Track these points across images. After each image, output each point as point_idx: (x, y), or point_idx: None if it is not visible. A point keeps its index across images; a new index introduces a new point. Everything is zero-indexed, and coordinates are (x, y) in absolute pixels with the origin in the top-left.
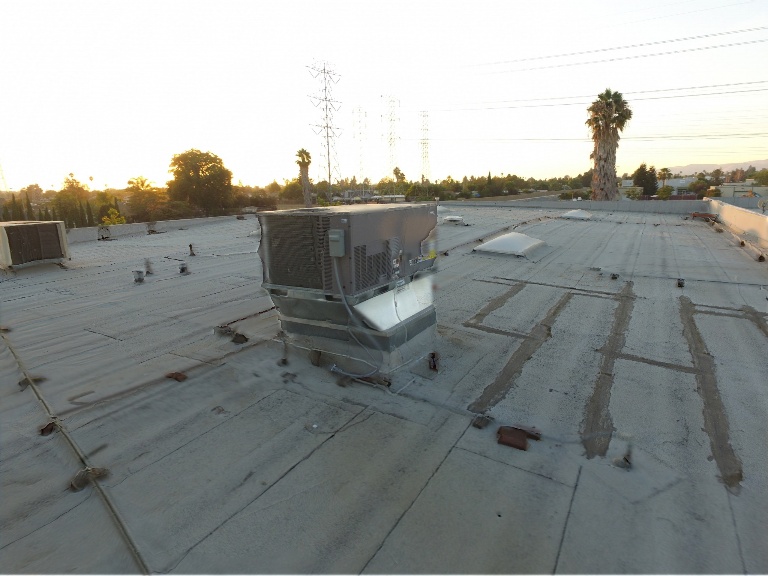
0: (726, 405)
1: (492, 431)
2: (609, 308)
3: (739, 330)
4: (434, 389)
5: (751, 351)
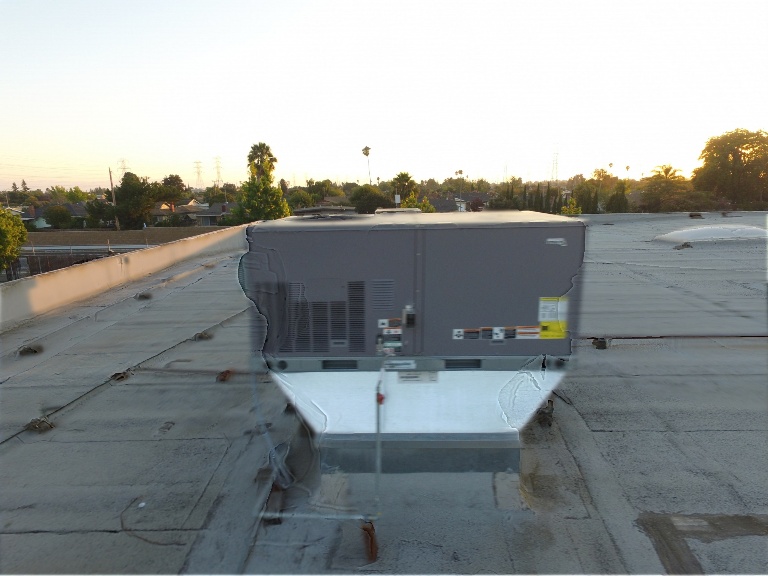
0: None
1: None
2: None
3: None
4: None
5: None
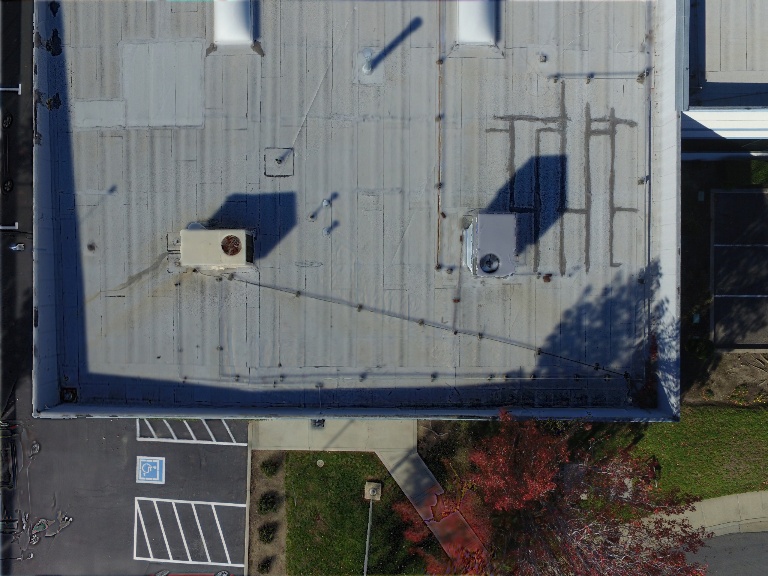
0: (591, 233)
1: (542, 279)
2: (557, 150)
3: (603, 155)
4: (522, 267)
5: (603, 182)
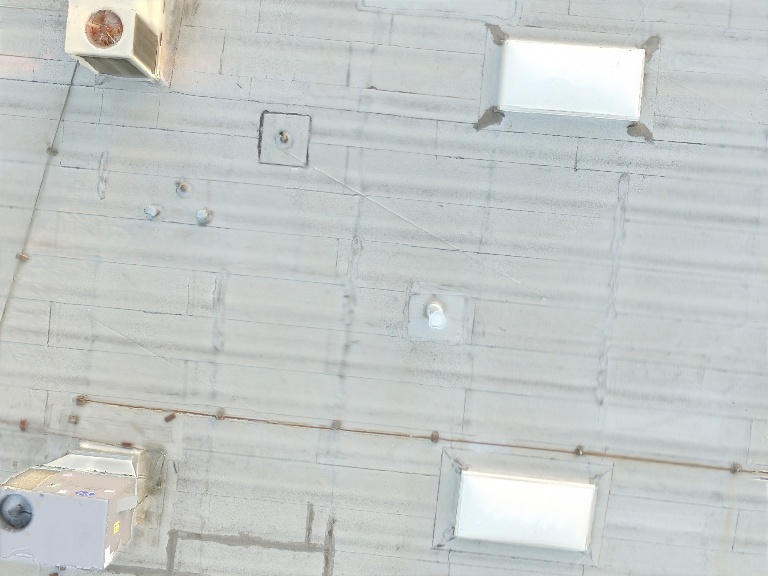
0: None
1: (56, 571)
2: None
3: None
4: None
5: None
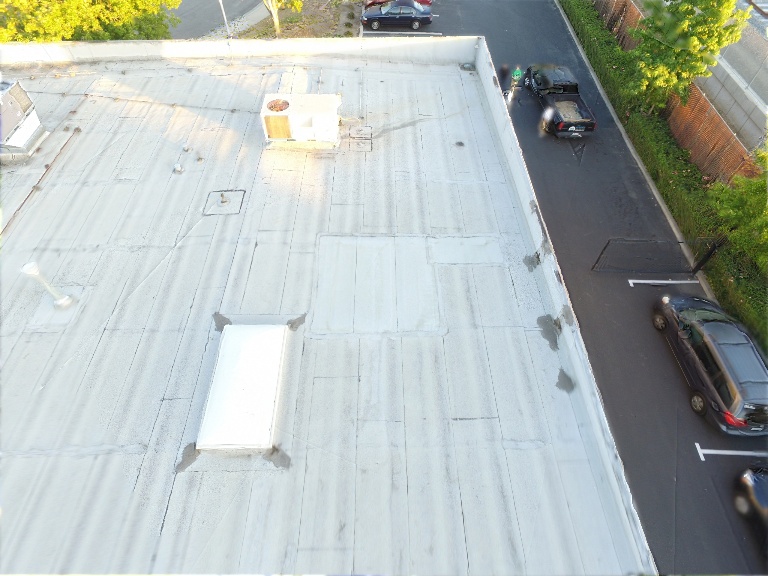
0: None
1: None
2: None
3: None
4: None
5: None
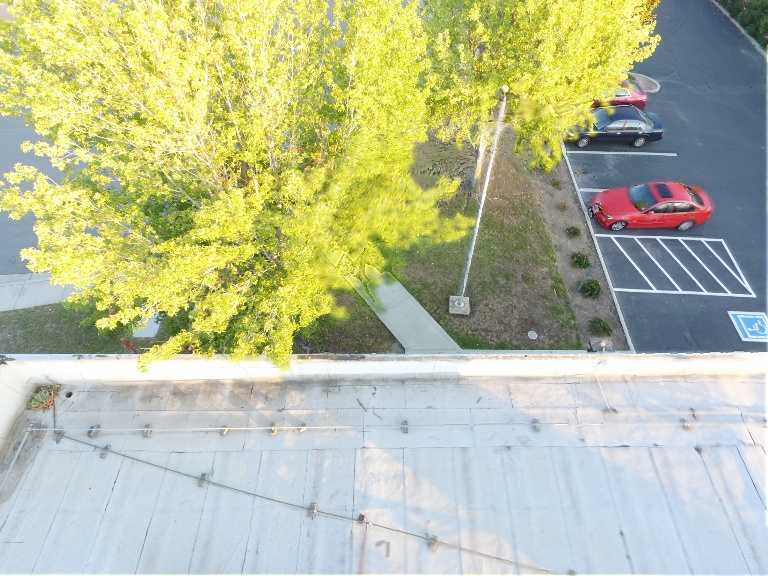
0: None
1: None
2: None
3: None
4: None
5: None
